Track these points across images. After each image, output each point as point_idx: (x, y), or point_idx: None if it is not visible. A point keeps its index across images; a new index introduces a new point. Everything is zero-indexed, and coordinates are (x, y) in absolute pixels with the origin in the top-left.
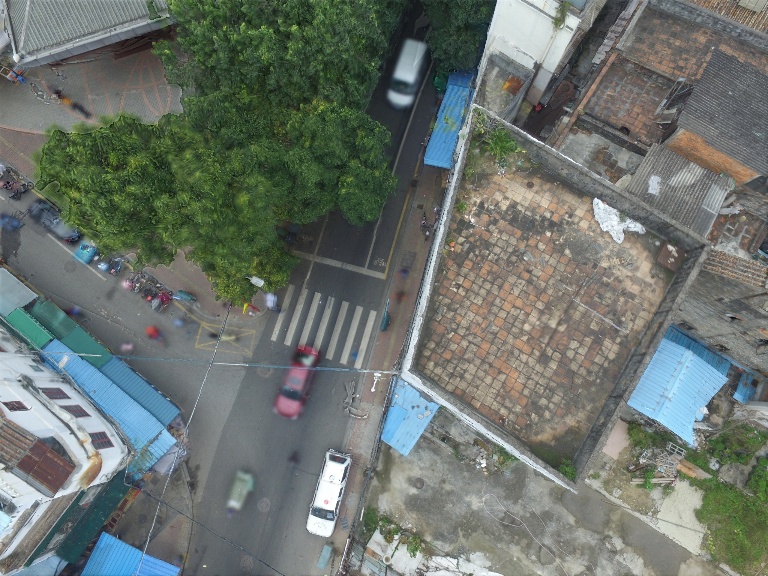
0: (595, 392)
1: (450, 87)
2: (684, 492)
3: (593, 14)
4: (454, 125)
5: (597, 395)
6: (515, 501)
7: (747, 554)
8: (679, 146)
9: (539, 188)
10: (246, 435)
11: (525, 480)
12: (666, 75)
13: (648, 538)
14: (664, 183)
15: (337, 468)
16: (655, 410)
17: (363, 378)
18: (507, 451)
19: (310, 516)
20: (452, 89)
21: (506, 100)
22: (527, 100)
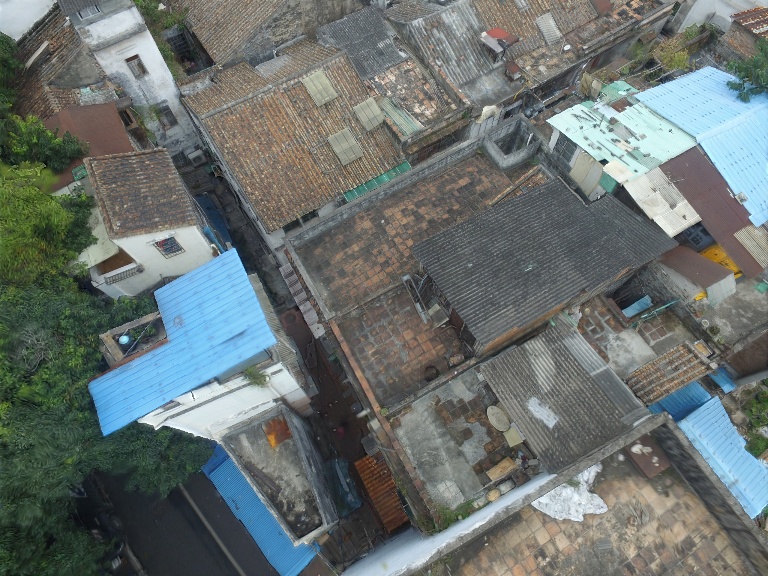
0: None
1: (213, 477)
2: None
3: (281, 340)
4: (265, 506)
5: None
6: None
7: None
8: (495, 342)
9: (482, 574)
10: None
11: None
12: (390, 287)
13: None
14: (542, 397)
15: None
16: (746, 506)
17: None
18: None
19: None
20: (217, 477)
21: (290, 452)
22: (298, 408)
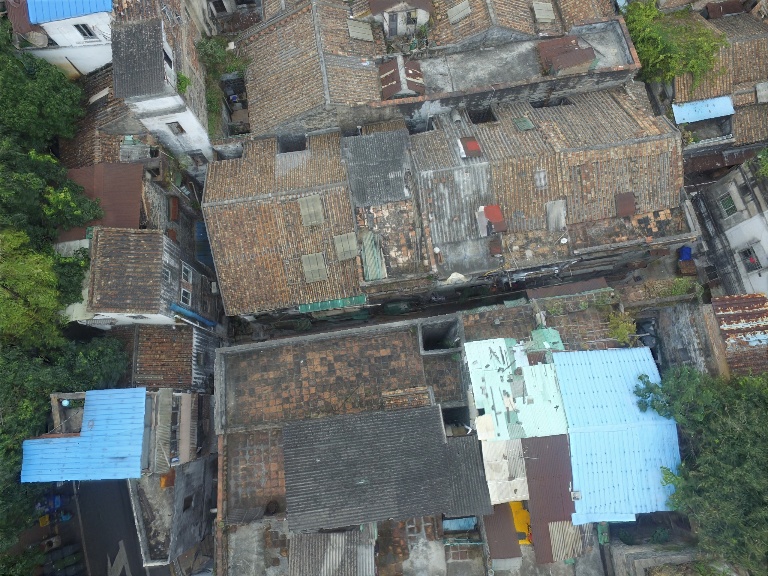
0: None
1: None
2: None
3: (164, 453)
4: None
5: None
6: None
7: None
8: None
9: None
10: None
11: None
12: (275, 427)
13: None
14: None
15: None
16: None
17: None
18: None
19: None
20: None
21: (171, 496)
22: None
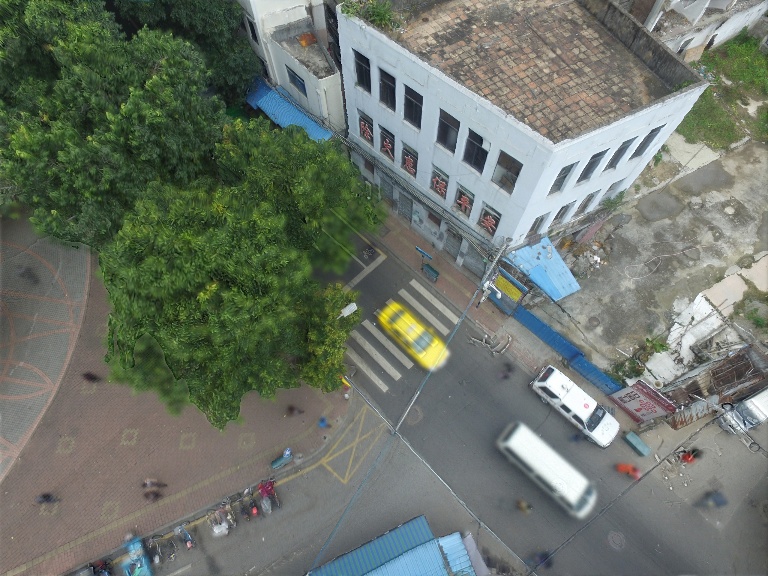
0: (621, 56)
1: (259, 103)
2: (670, 141)
3: None
4: (295, 115)
5: (624, 56)
6: (638, 253)
7: (728, 128)
8: None
9: (432, 16)
10: (474, 471)
11: (623, 237)
12: None
13: (698, 180)
14: None
15: (556, 377)
16: None
17: (472, 322)
18: (613, 198)
19: (593, 434)
20: (262, 102)
21: (315, 50)
22: None
